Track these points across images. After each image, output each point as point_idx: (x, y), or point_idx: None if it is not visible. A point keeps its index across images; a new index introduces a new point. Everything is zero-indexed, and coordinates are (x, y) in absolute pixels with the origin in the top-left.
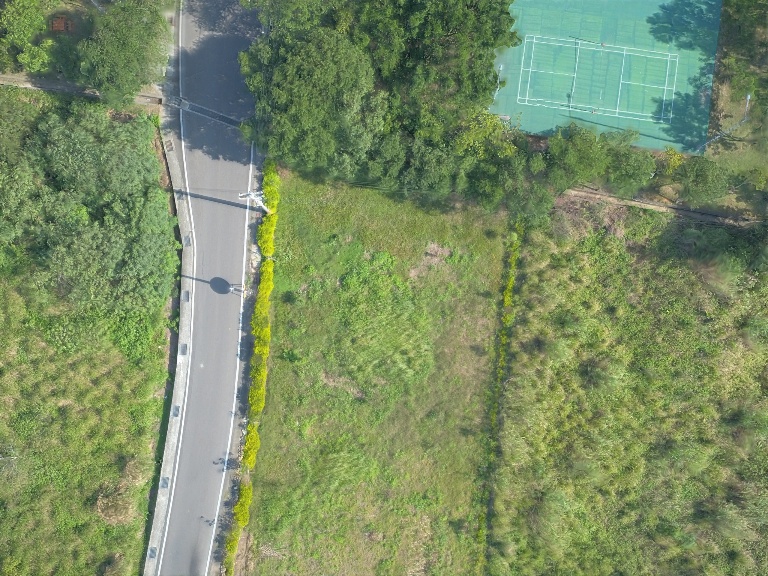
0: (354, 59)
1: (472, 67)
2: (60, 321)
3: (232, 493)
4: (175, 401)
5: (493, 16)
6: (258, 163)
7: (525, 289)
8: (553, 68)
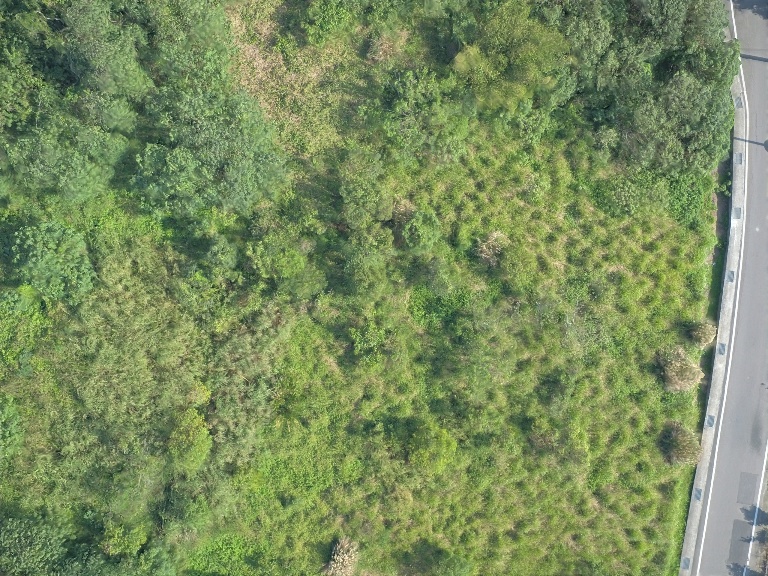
0: None
1: None
2: (610, 185)
3: None
4: (730, 266)
5: None
6: None
7: None
8: None
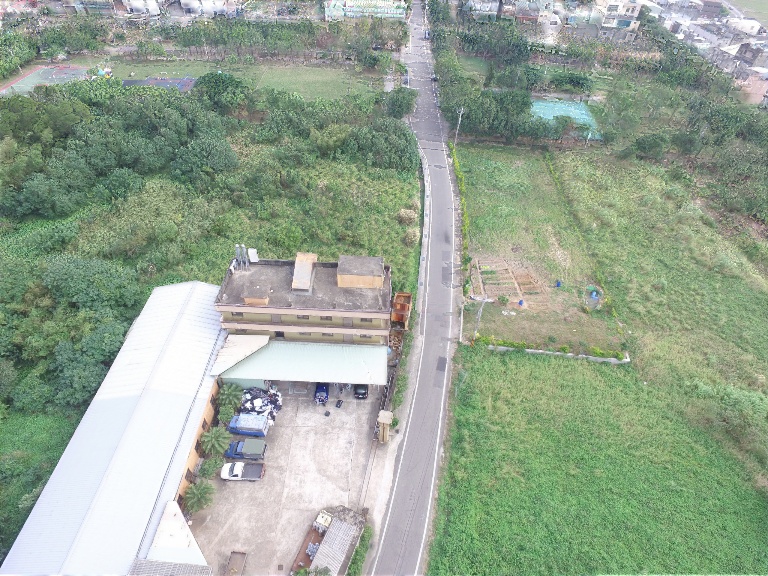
0: None
1: None
2: None
3: (458, 217)
4: (426, 194)
5: None
6: (445, 142)
7: None
8: None
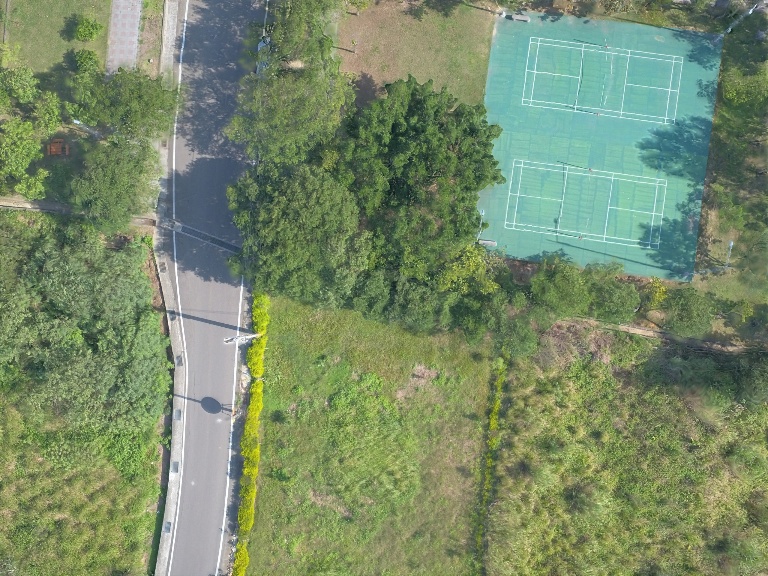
0: (339, 200)
1: (455, 210)
2: (57, 438)
3: None
4: (167, 517)
5: (477, 158)
6: (249, 285)
7: (511, 413)
8: (541, 193)
